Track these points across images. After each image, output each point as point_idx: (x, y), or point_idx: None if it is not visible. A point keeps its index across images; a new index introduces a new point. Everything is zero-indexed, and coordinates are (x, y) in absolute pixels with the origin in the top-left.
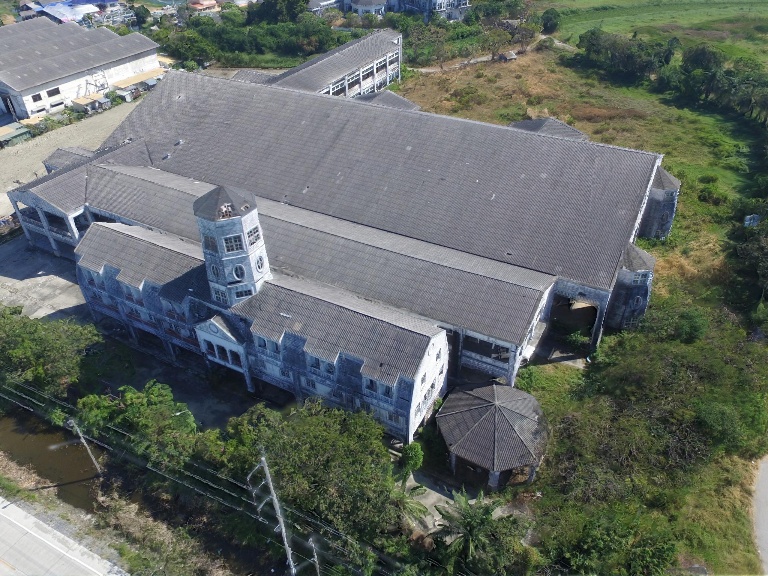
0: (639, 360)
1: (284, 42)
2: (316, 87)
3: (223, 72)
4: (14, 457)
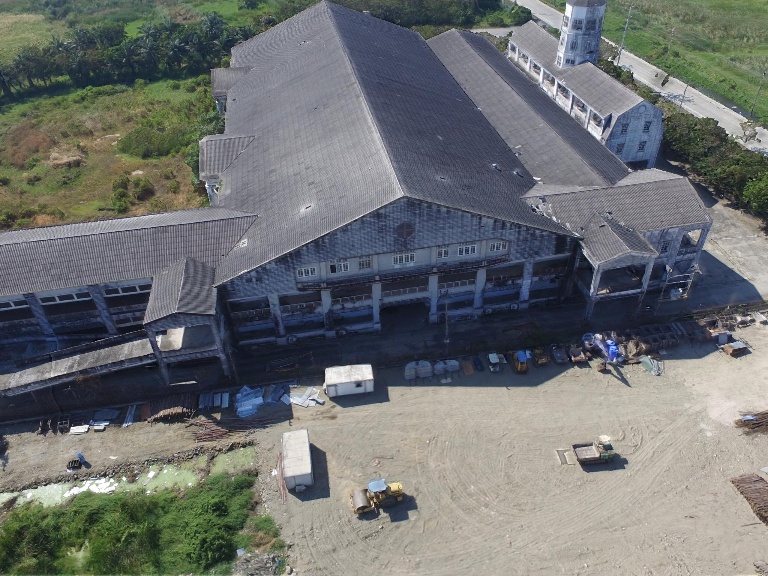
0: None
1: None
2: (199, 211)
3: None
4: None
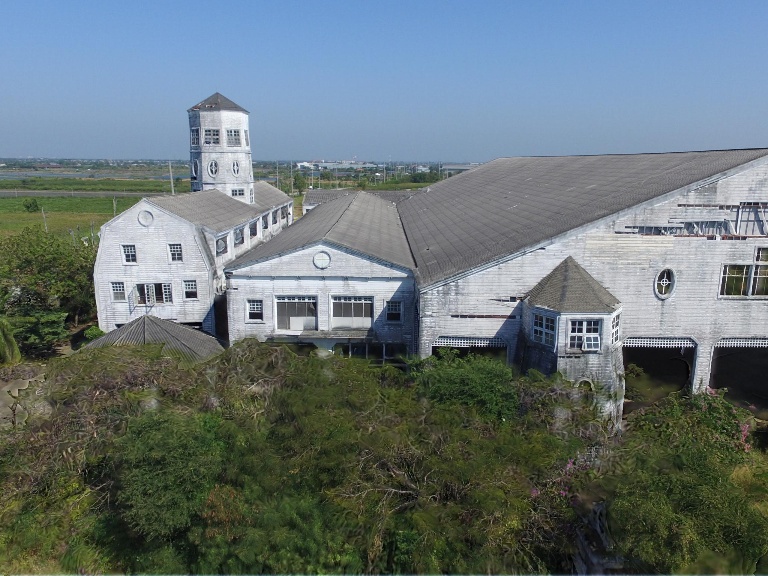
0: None
1: None
2: None
3: None
4: None
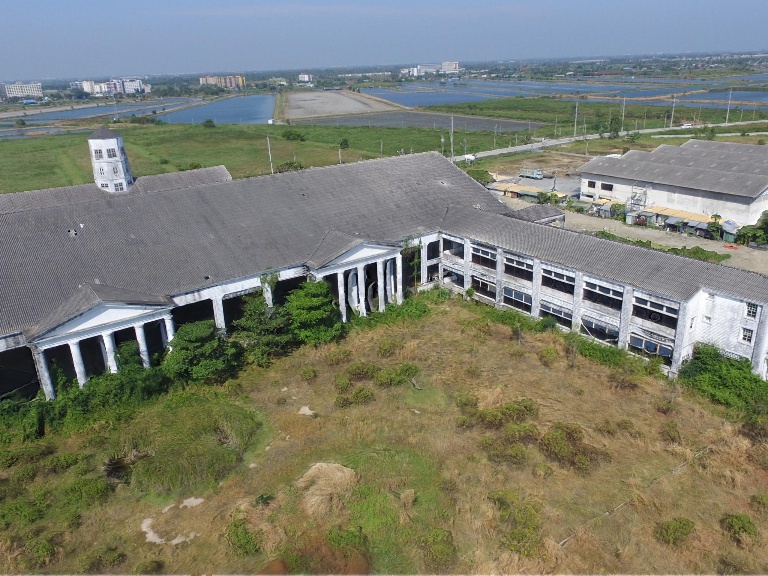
0: None
1: None
2: (456, 229)
3: (755, 258)
4: None
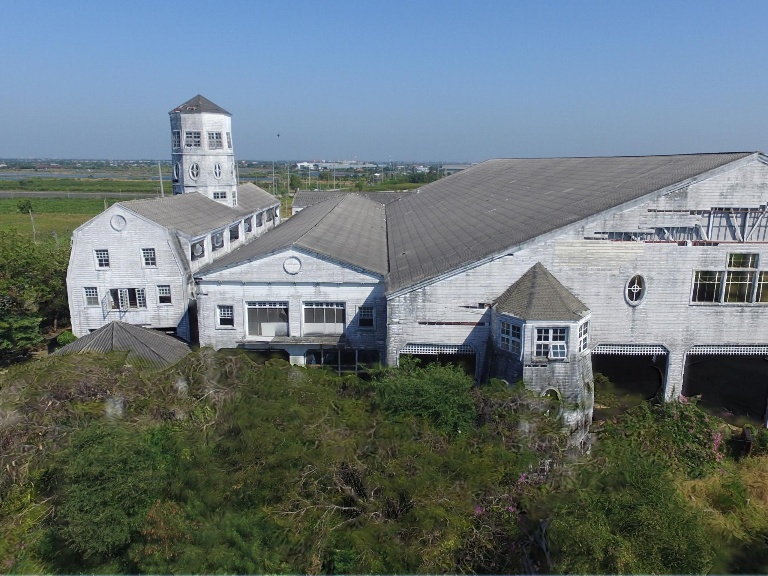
0: (239, 356)
1: None
2: None
3: None
4: None
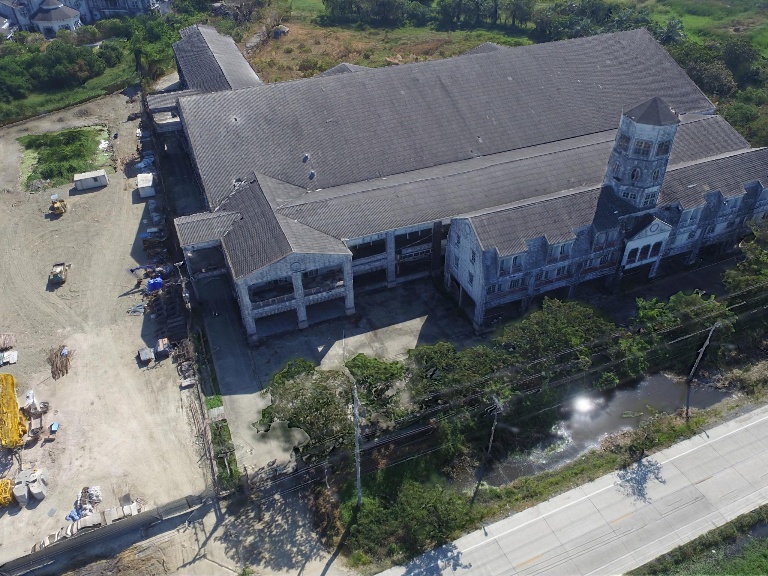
0: None
1: (47, 76)
2: None
3: (18, 129)
4: (633, 426)
